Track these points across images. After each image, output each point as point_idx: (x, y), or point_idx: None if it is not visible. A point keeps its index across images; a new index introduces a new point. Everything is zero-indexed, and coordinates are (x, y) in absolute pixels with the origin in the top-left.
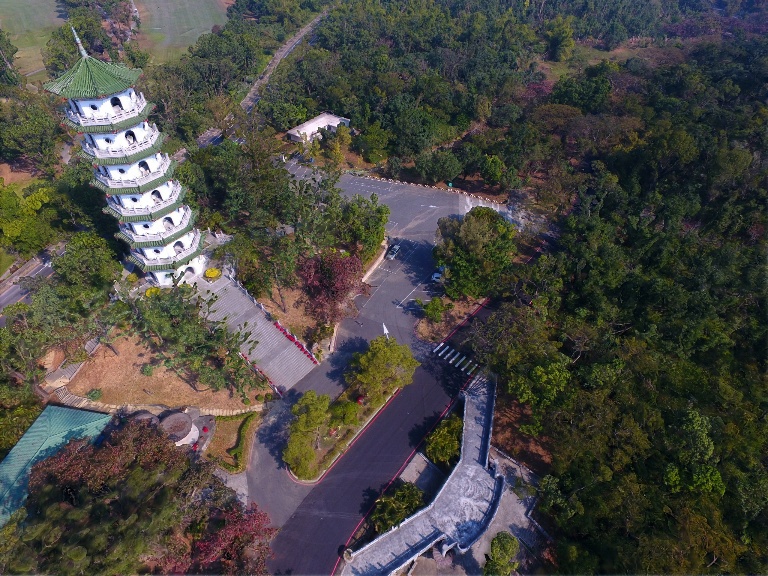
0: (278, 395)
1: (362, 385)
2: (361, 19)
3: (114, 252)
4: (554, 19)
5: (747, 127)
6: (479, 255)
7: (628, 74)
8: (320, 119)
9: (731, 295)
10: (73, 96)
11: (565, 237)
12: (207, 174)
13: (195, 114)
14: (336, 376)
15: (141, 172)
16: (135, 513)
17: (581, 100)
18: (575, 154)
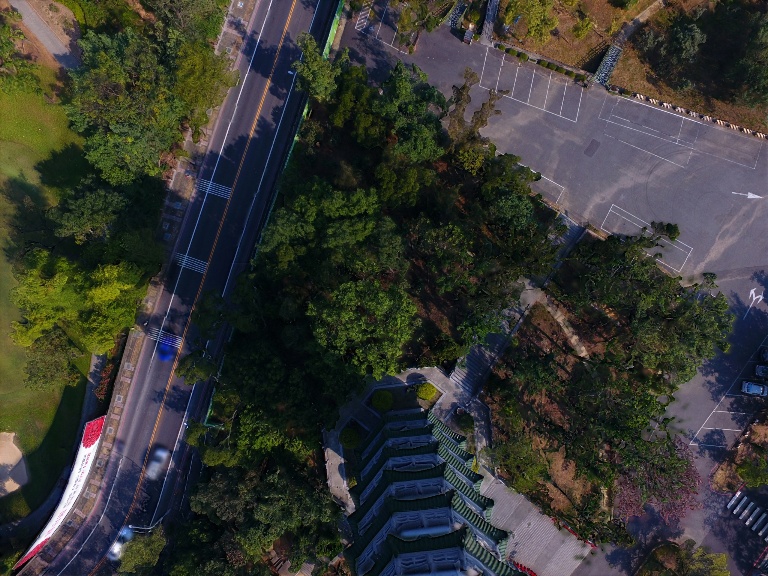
0: None
1: (648, 571)
2: None
3: None
4: None
5: None
6: None
7: None
8: None
9: None
10: None
11: None
12: None
13: None
14: (617, 559)
15: None
16: None
17: None
18: None
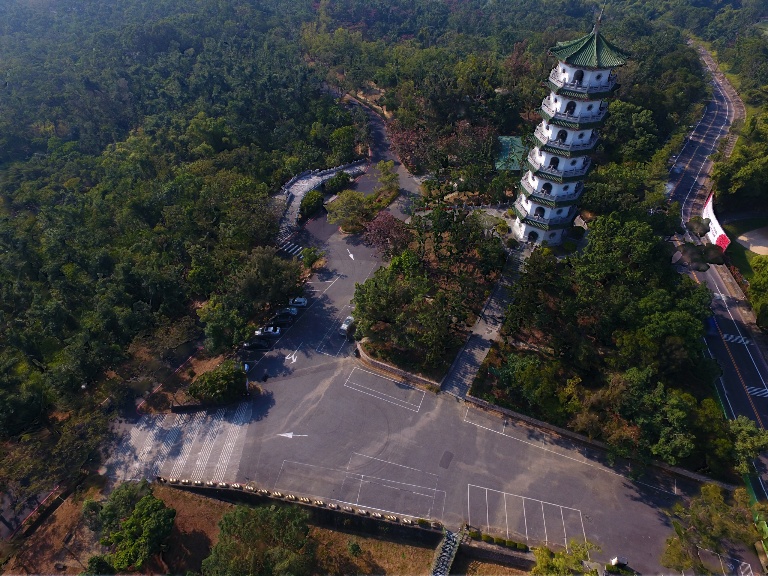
0: None
1: None
2: None
3: None
4: None
5: None
6: None
7: None
8: None
9: None
10: None
11: None
12: None
13: None
14: None
15: None
16: None
17: None
18: None
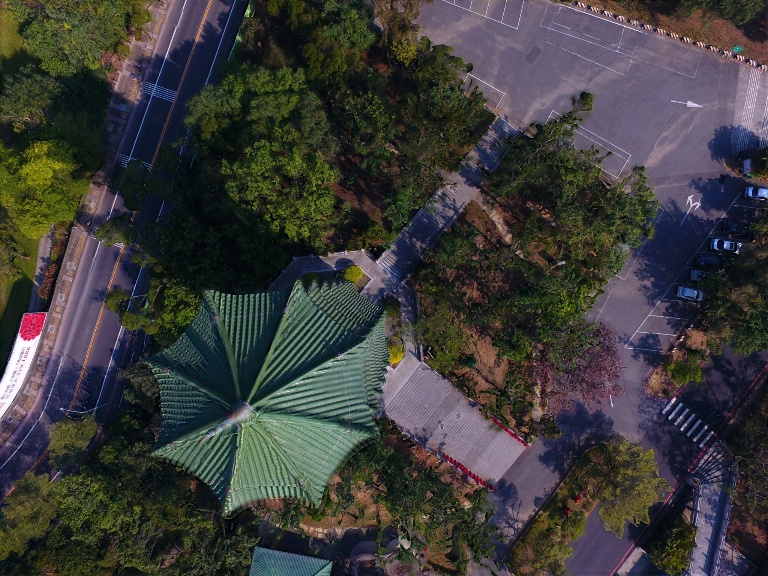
0: None
1: (581, 472)
2: None
3: None
4: None
5: None
6: None
7: None
8: None
9: None
10: (253, 504)
11: None
12: (319, 88)
13: None
14: (551, 460)
15: None
16: None
17: None
18: None
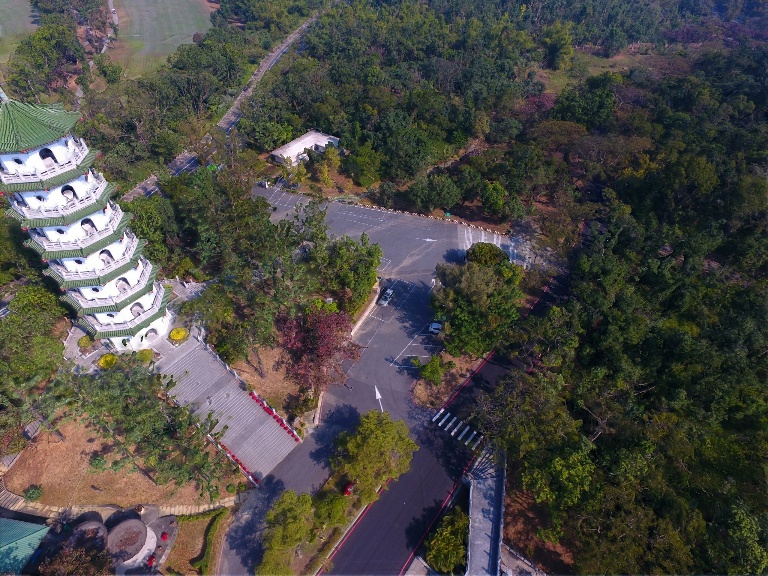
0: (253, 484)
1: None
2: (351, 26)
3: (65, 310)
4: (552, 25)
5: (766, 149)
6: (483, 308)
7: (633, 86)
8: (307, 138)
9: (763, 347)
10: None
11: (579, 286)
12: (178, 209)
13: (170, 135)
14: (321, 456)
15: (85, 231)
16: None
17: (585, 115)
18: (581, 177)
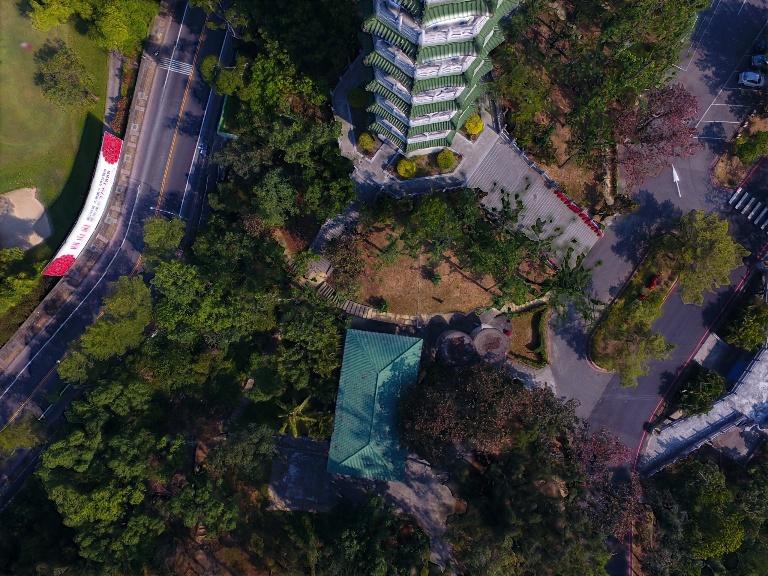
0: None
1: (654, 260)
2: None
3: (324, 97)
4: None
5: None
6: None
7: None
8: None
9: None
10: None
11: None
12: None
13: None
14: (623, 250)
15: None
16: (526, 465)
17: None
18: None
